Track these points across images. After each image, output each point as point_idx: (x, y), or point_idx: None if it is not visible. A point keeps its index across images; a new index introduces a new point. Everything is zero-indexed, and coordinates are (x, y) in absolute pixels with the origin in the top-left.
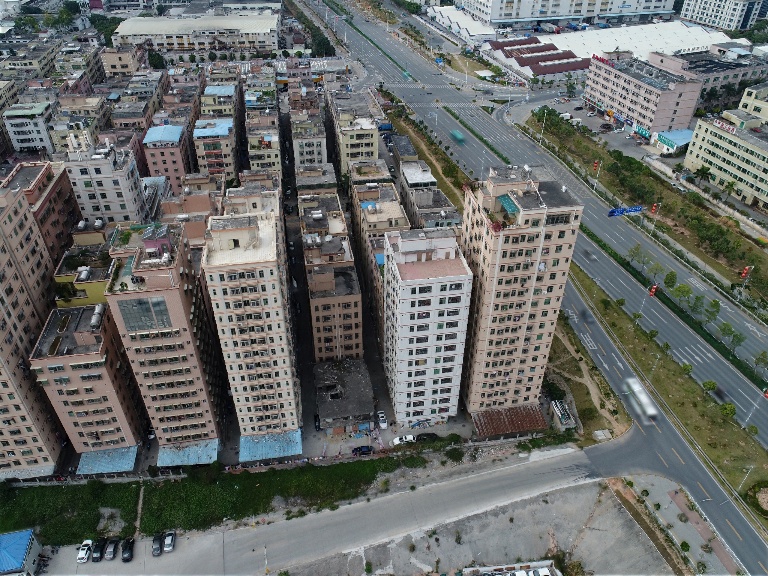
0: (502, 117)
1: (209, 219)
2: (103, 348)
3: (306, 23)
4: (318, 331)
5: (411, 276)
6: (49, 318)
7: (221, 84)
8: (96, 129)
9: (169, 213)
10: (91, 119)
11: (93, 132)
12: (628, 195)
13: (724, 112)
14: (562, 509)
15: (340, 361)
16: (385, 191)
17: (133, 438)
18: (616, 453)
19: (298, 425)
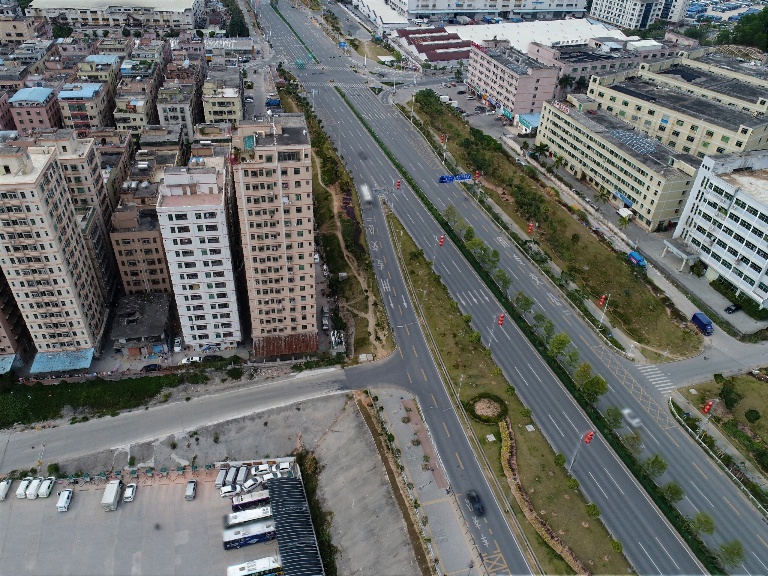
0: (387, 98)
1: None
2: None
3: (229, 6)
4: (123, 265)
5: (171, 205)
6: None
7: (109, 54)
8: None
9: None
10: None
11: None
12: (473, 167)
13: (568, 95)
14: (312, 415)
15: (147, 294)
16: (221, 150)
17: None
18: (371, 372)
19: (93, 345)
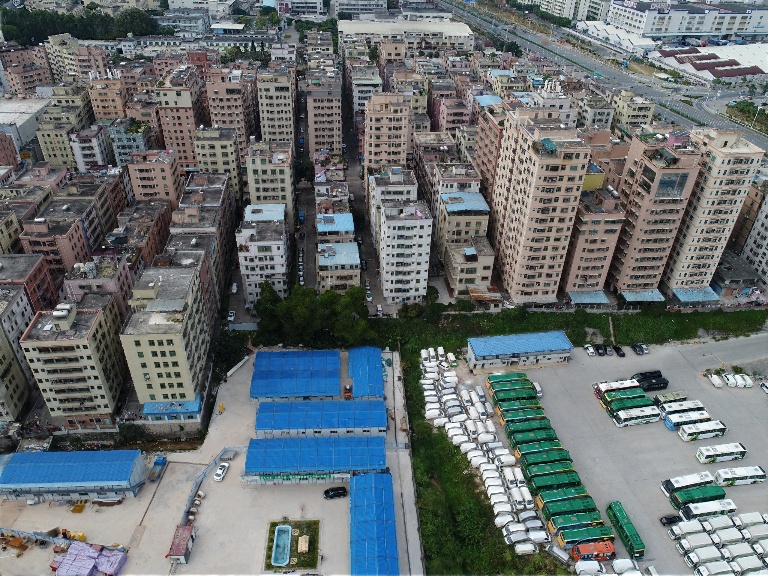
0: (703, 108)
1: None
2: None
3: (479, 31)
4: None
5: None
6: None
7: None
8: None
9: None
10: None
11: None
12: None
13: None
14: None
15: None
16: None
17: None
18: None
19: None
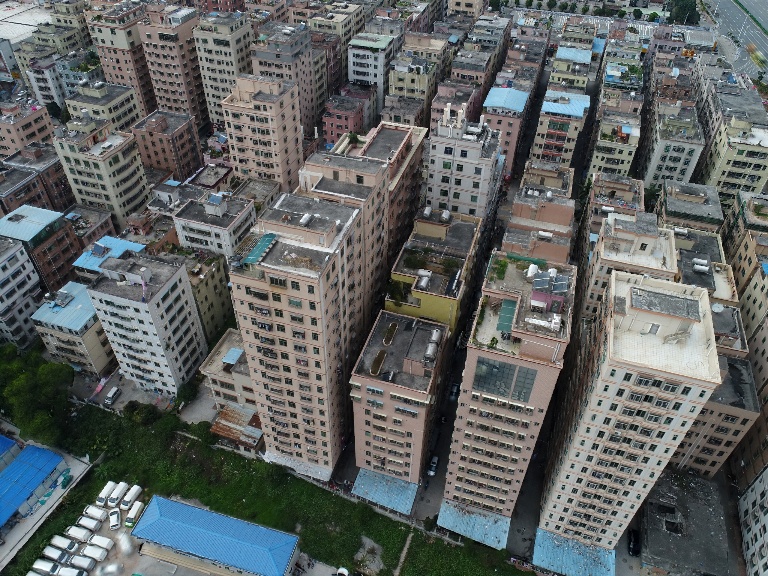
0: None
1: (613, 274)
2: (430, 386)
3: None
4: None
5: None
6: (377, 322)
7: (572, 45)
8: (433, 76)
9: (518, 216)
10: (431, 64)
11: (430, 79)
12: None
13: None
14: None
15: (683, 474)
16: None
17: (418, 477)
18: None
19: None
